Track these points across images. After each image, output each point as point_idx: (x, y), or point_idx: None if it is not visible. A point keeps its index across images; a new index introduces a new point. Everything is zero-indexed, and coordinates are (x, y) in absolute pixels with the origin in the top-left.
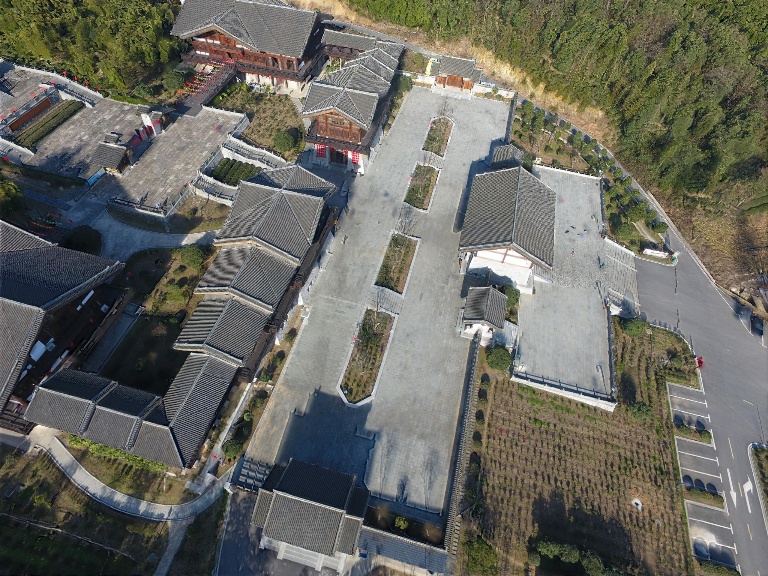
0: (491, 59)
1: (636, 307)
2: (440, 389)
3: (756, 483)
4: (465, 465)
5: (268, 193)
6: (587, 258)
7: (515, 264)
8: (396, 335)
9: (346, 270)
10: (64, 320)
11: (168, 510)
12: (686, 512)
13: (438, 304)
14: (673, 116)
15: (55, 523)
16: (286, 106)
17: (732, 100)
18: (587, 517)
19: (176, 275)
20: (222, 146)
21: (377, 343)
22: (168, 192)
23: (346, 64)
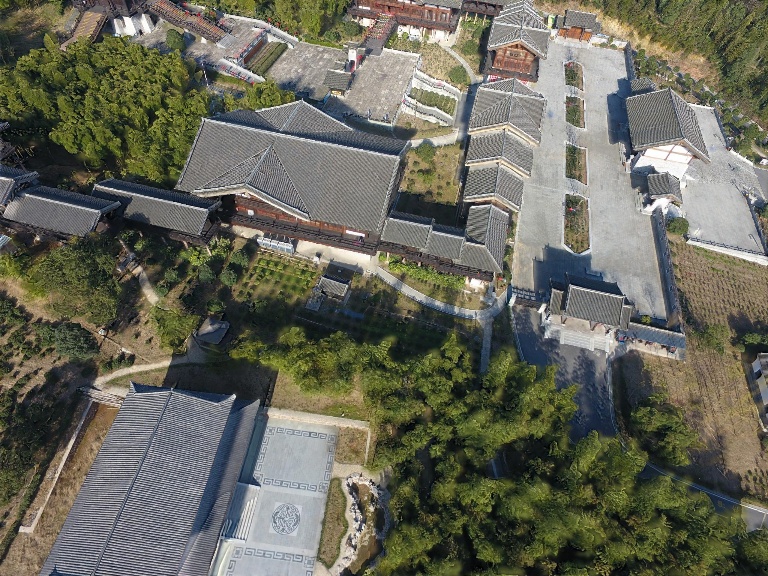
0: (600, 16)
1: (764, 200)
2: (638, 246)
3: None
4: None
5: (502, 96)
6: (720, 164)
7: (676, 161)
8: (592, 212)
9: (540, 167)
10: None
11: (474, 313)
12: None
13: (616, 192)
14: None
15: None
16: (441, 51)
17: None
18: (767, 327)
19: (415, 167)
20: (414, 77)
21: (581, 216)
22: (386, 109)
23: (501, 13)
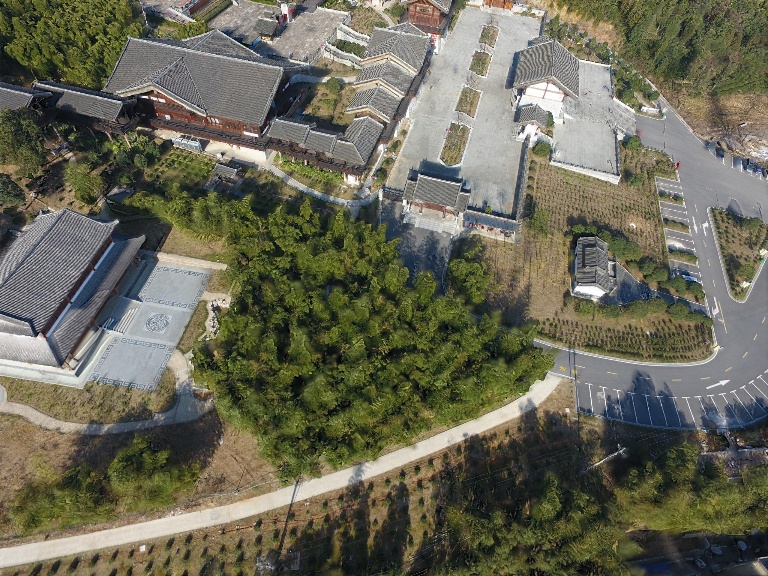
0: None
1: None
2: (504, 163)
3: (711, 224)
4: (523, 199)
5: (392, 35)
6: (601, 108)
7: (552, 99)
8: (472, 137)
9: (434, 103)
10: (278, 93)
11: (347, 201)
12: (664, 233)
13: (499, 124)
14: (666, 25)
15: (284, 199)
16: (373, 14)
17: (711, 16)
18: None
19: (323, 97)
20: (338, 29)
21: (461, 139)
22: (307, 53)
23: None
